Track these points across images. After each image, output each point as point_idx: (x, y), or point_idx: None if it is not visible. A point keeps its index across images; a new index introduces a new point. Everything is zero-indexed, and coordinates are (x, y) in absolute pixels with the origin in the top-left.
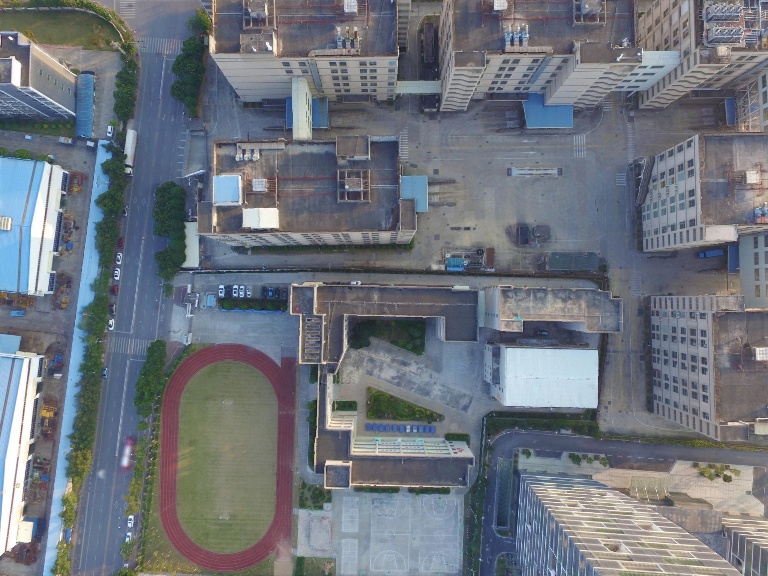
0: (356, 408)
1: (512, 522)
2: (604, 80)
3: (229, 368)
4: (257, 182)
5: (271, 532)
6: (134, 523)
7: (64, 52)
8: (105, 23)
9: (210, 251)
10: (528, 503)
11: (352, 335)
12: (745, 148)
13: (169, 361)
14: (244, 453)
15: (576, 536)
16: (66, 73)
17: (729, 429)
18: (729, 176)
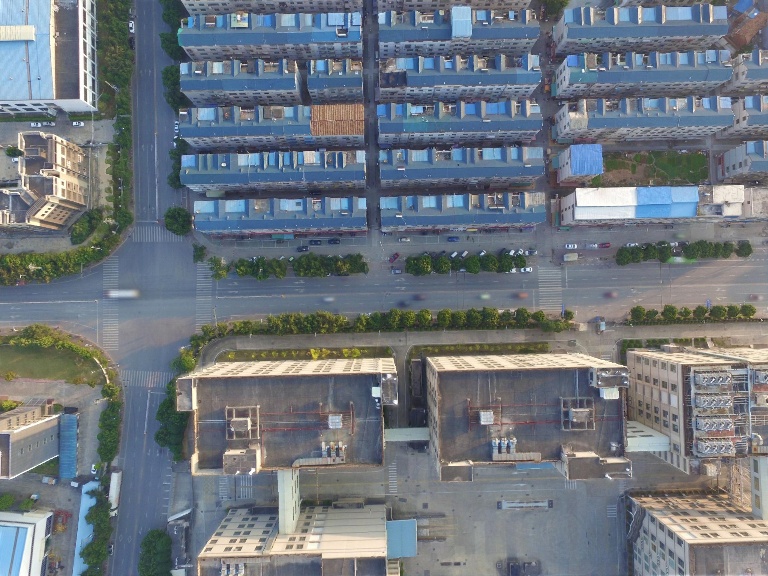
0: None
1: None
2: None
3: None
4: None
5: None
6: None
7: (46, 386)
8: None
9: None
10: None
11: None
12: (736, 553)
13: None
14: None
15: None
16: (48, 423)
17: None
18: None
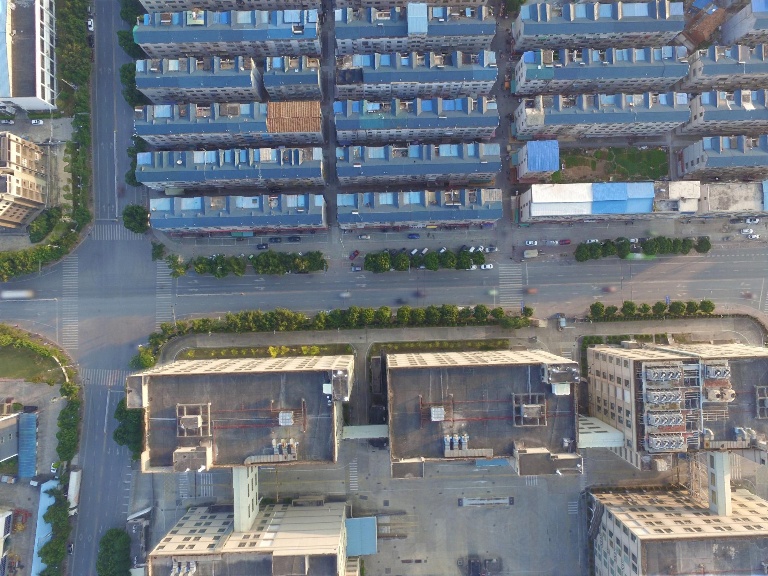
0: None
1: None
2: None
3: None
4: None
5: None
6: None
7: (6, 385)
8: None
9: None
10: None
11: None
12: (688, 548)
13: None
14: None
15: None
16: (6, 422)
17: None
18: None
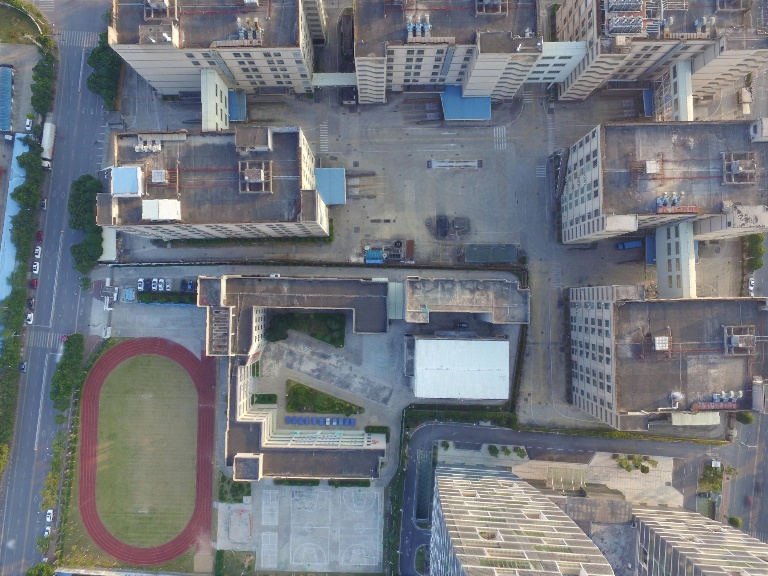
0: (276, 401)
1: (431, 514)
2: (511, 71)
3: (149, 362)
4: (156, 173)
5: (191, 526)
6: (53, 517)
7: None
8: (24, 16)
9: (129, 244)
10: (435, 494)
11: (268, 328)
12: (648, 138)
13: (88, 355)
14: (164, 447)
15: (454, 524)
16: None
17: (629, 419)
18: (631, 166)
